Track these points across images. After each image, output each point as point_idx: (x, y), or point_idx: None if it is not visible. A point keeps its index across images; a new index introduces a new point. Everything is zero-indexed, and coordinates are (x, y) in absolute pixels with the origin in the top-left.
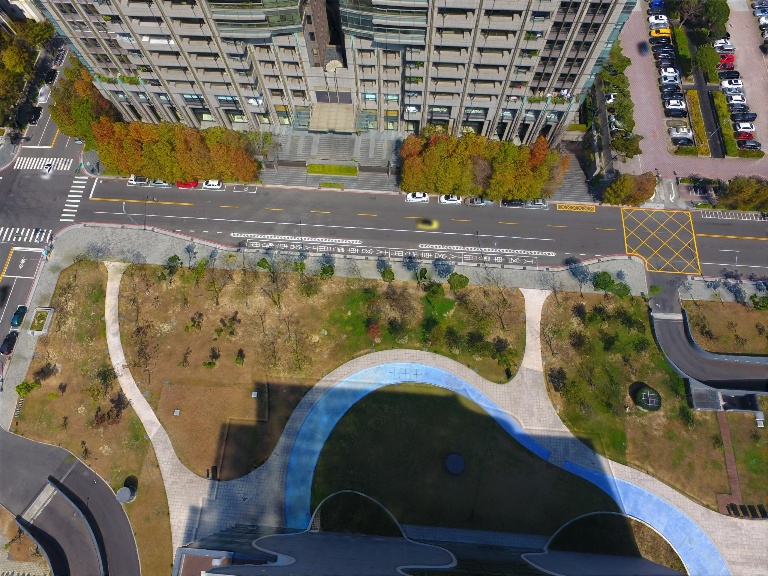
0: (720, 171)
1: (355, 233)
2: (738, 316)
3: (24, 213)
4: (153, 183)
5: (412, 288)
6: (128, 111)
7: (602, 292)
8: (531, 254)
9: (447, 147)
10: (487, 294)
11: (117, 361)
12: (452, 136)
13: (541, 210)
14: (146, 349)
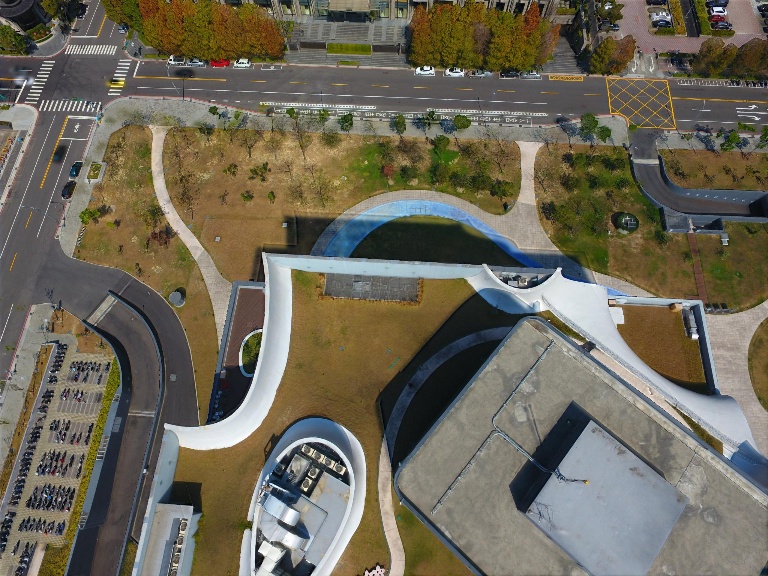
0: (695, 47)
1: (370, 100)
2: (708, 160)
3: (76, 89)
4: (190, 62)
5: (421, 143)
6: (167, 1)
7: (588, 143)
8: (526, 115)
9: (451, 16)
10: (487, 146)
11: (164, 202)
12: (456, 4)
13: (535, 80)
14: (189, 192)
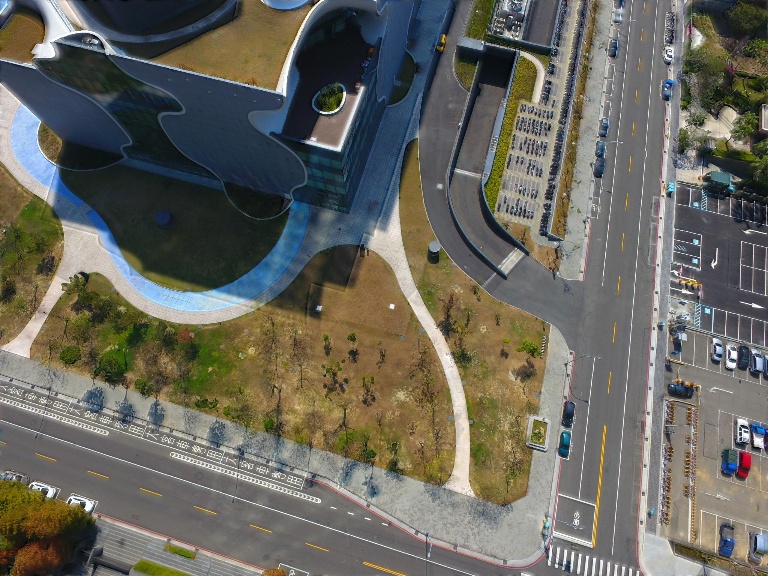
0: None
1: (174, 468)
2: None
3: None
4: None
5: None
6: None
7: None
8: None
9: None
10: None
11: (452, 370)
12: None
13: None
14: None
